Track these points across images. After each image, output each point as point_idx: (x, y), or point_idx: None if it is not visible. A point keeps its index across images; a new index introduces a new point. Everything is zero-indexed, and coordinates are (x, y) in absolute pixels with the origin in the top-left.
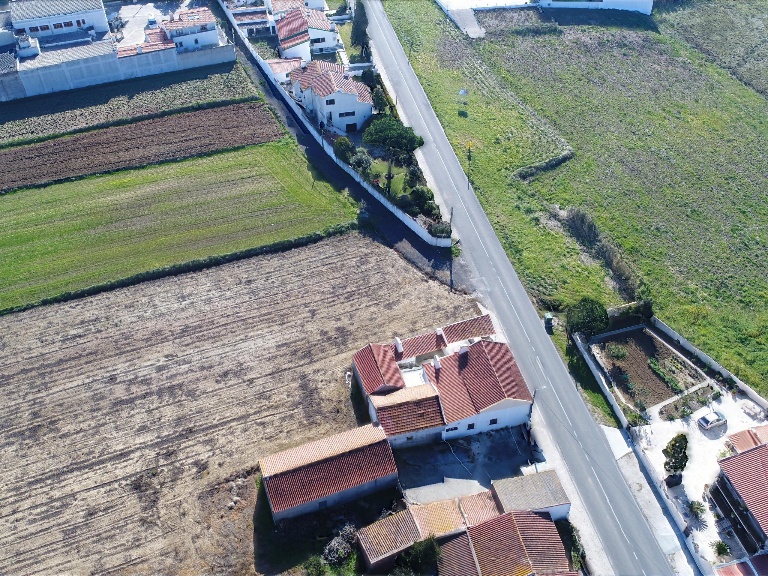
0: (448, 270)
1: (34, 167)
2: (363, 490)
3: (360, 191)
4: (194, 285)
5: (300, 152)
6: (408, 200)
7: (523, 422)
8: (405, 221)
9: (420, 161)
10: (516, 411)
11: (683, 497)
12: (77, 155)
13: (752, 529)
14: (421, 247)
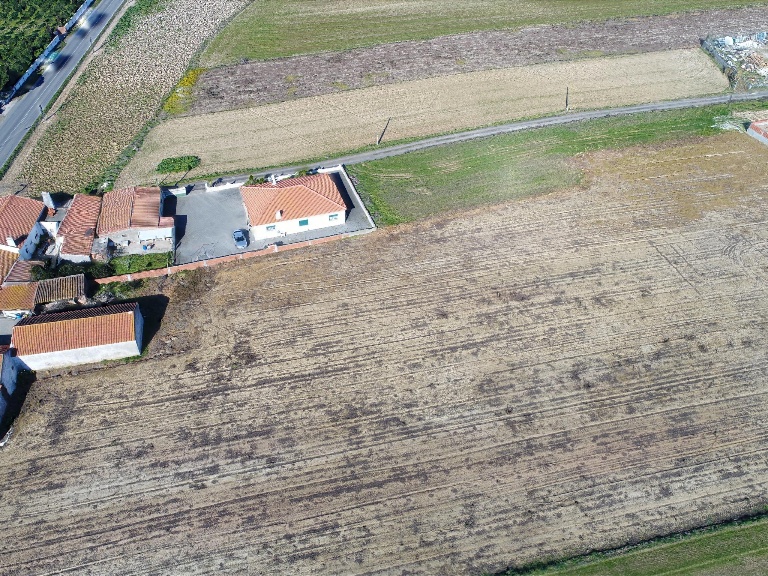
0: None
1: None
2: None
3: None
4: None
5: None
6: None
7: None
8: None
9: None
10: None
11: None
12: None
13: None
14: None
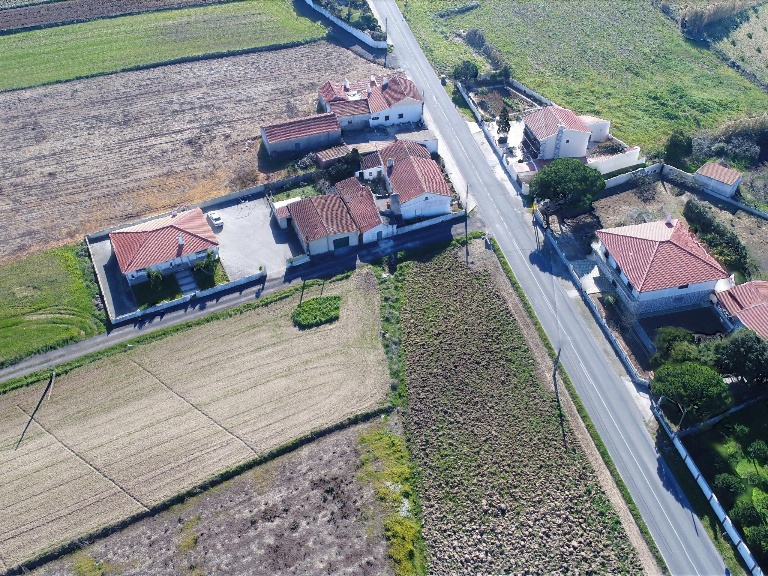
0: (384, 59)
1: (106, 7)
2: (321, 141)
3: (329, 22)
4: (219, 64)
5: (289, 2)
6: (360, 22)
7: (419, 119)
8: (358, 36)
9: (371, 7)
10: (414, 109)
11: (507, 147)
12: (135, 1)
13: (536, 147)
14: (367, 48)
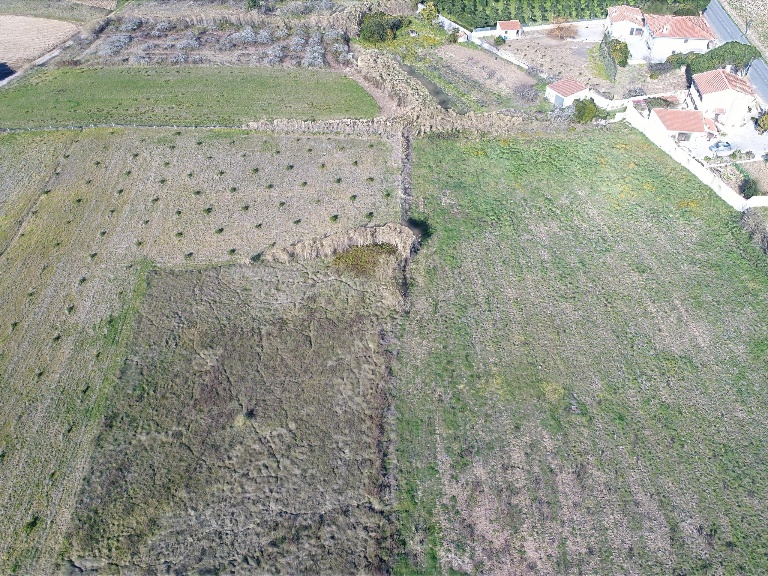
0: None
1: None
2: None
3: None
4: None
5: None
6: None
7: None
8: None
9: None
10: None
11: None
12: None
13: None
14: None
